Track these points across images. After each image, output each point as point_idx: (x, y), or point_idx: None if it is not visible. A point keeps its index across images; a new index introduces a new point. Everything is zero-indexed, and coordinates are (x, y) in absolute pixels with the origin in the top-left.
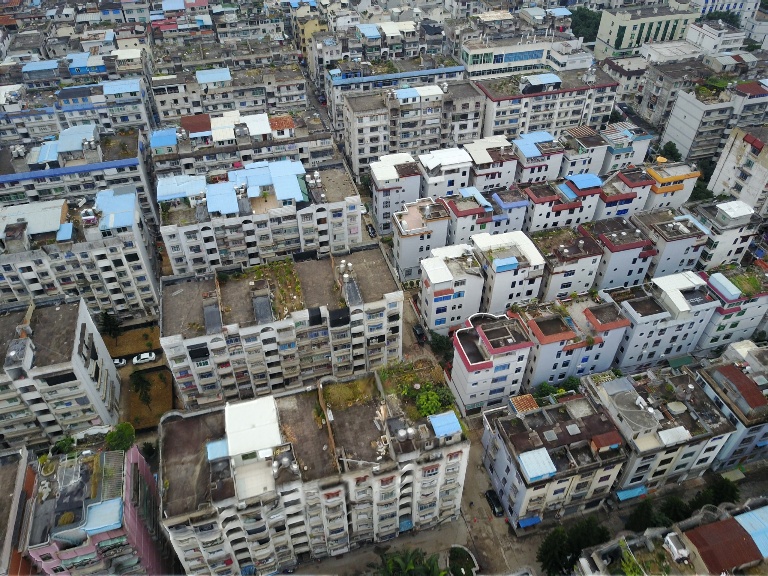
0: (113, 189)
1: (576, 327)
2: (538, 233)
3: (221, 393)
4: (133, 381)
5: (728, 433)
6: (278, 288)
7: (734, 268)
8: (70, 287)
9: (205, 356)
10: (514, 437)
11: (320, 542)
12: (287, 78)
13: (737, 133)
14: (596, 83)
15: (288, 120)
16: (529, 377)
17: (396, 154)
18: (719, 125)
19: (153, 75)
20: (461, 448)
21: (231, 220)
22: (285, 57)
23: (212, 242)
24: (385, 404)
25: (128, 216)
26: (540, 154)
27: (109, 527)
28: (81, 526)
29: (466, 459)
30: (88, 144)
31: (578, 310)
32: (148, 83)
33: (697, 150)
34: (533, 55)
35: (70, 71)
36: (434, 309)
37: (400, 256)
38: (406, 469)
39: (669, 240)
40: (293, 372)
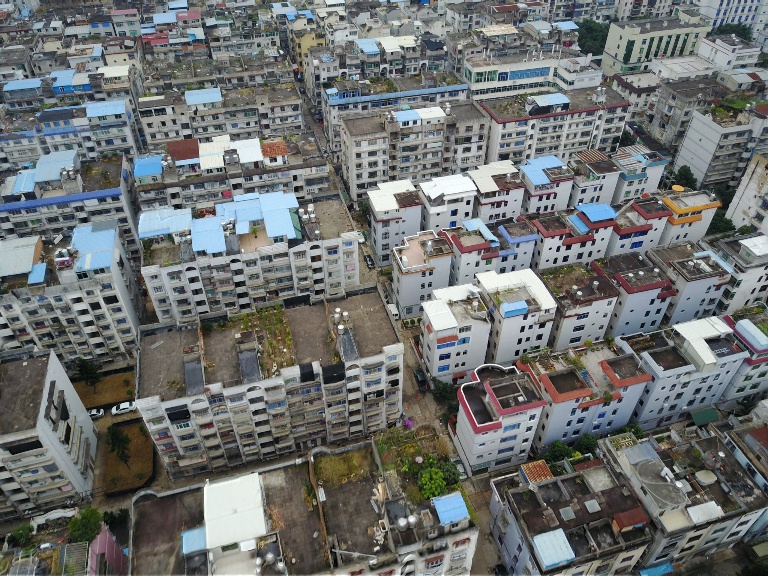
0: (92, 224)
1: (592, 382)
2: (548, 271)
3: (205, 454)
4: (111, 434)
5: (764, 508)
6: (267, 339)
7: (762, 313)
8: (44, 331)
9: (186, 418)
10: (527, 515)
11: None
12: (281, 98)
13: (759, 160)
14: (606, 103)
15: (281, 146)
16: (541, 434)
17: (396, 181)
18: (737, 148)
19: (140, 95)
20: (469, 535)
21: (218, 259)
22: (280, 74)
23: (197, 282)
24: (383, 482)
25: (106, 256)
26: (549, 181)
27: None
28: None
29: (474, 545)
30: (67, 174)
31: (593, 360)
32: (134, 104)
33: (713, 174)
34: (539, 72)
35: (54, 90)
36: (437, 355)
37: (400, 293)
38: (407, 560)
39: (690, 280)
40: (283, 430)
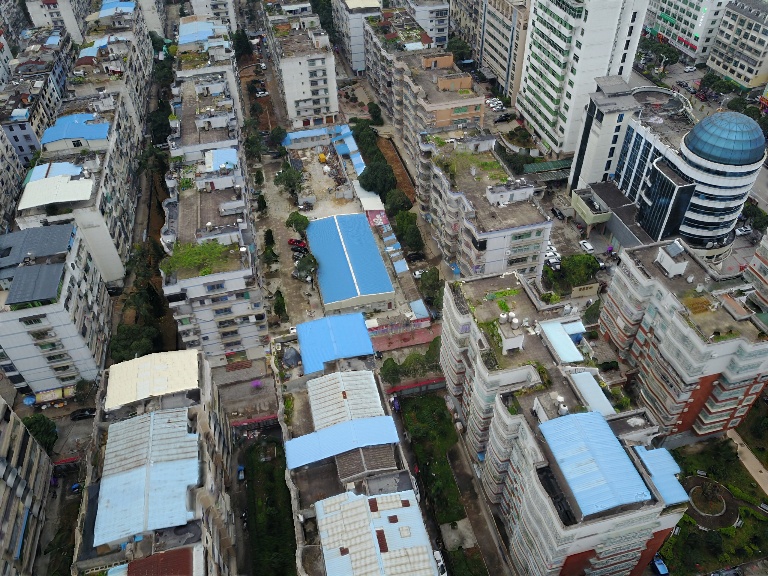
0: None
1: None
2: None
3: None
4: None
5: (49, 76)
6: None
7: None
8: None
9: None
10: (0, 117)
11: (3, 198)
12: None
13: None
14: None
15: None
16: None
17: None
18: None
19: None
20: None
21: None
22: None
23: None
24: None
25: None
26: None
27: None
28: None
29: None
30: None
31: None
32: None
33: None
34: None
35: None
36: None
37: None
38: None
39: None
40: None
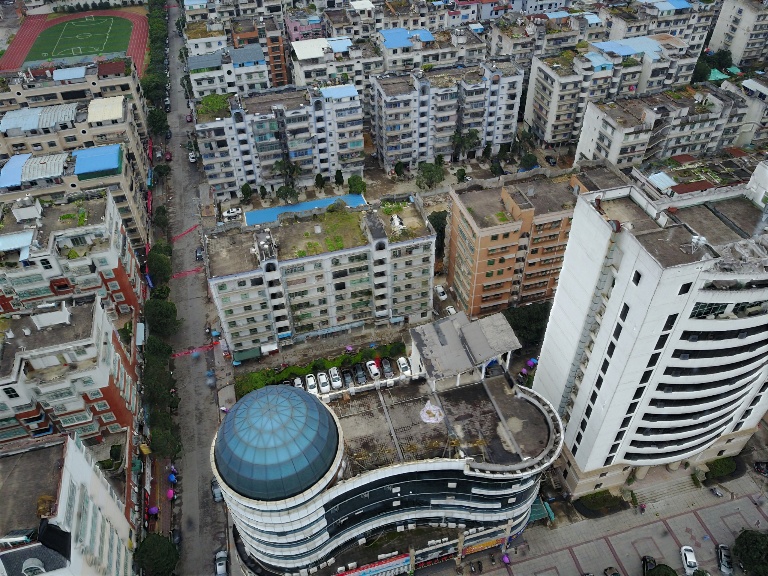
0: None
1: (499, 0)
2: None
3: None
4: None
5: None
6: None
7: None
8: None
9: (333, 6)
10: None
11: None
12: None
13: None
14: None
15: None
16: None
17: None
18: None
19: None
20: (444, 12)
21: None
22: None
23: None
24: (414, 3)
25: None
26: None
27: (316, 21)
28: (307, 19)
29: (447, 22)
30: None
31: None
32: None
33: None
34: None
35: None
36: None
37: None
38: (423, 20)
39: None
40: None
